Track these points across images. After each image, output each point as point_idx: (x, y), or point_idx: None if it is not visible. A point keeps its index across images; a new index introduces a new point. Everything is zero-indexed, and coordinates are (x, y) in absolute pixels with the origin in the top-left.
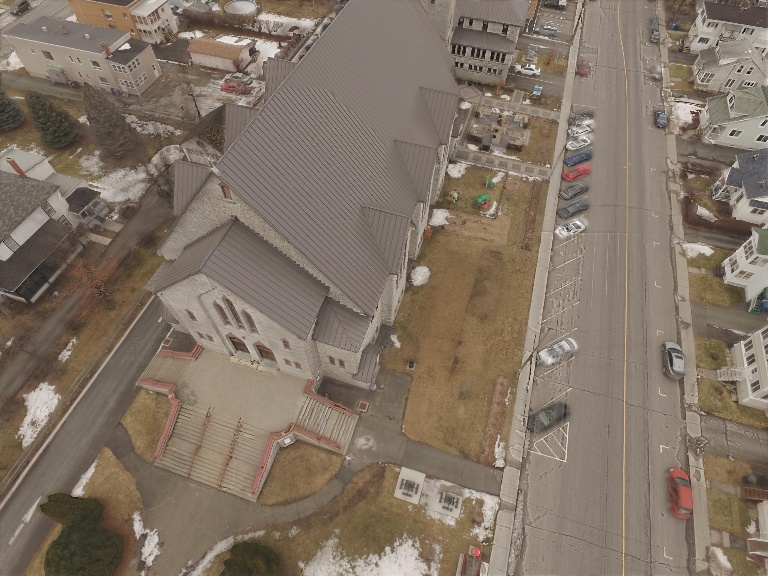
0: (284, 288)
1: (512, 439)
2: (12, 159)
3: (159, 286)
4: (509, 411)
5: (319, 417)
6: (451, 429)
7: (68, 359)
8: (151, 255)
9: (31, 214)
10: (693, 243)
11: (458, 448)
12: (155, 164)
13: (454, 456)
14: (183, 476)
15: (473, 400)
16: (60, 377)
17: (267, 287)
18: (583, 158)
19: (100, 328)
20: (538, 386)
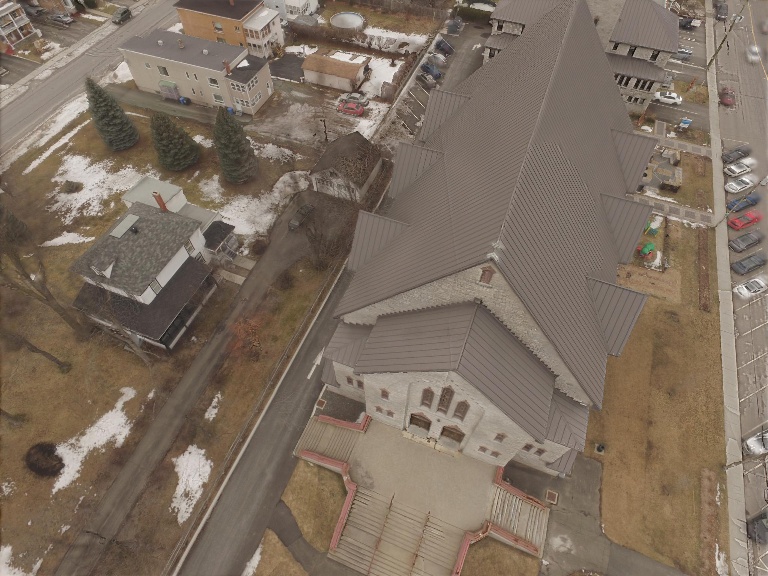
0: (522, 382)
1: (733, 550)
2: (158, 193)
3: (365, 366)
4: (723, 514)
5: (511, 511)
6: (659, 533)
7: (215, 418)
8: (289, 298)
9: (176, 254)
10: None
11: (672, 558)
12: (279, 192)
13: (669, 568)
14: (361, 573)
15: (679, 497)
16: (210, 439)
17: (509, 383)
18: (748, 203)
19: (245, 382)
20: (750, 483)
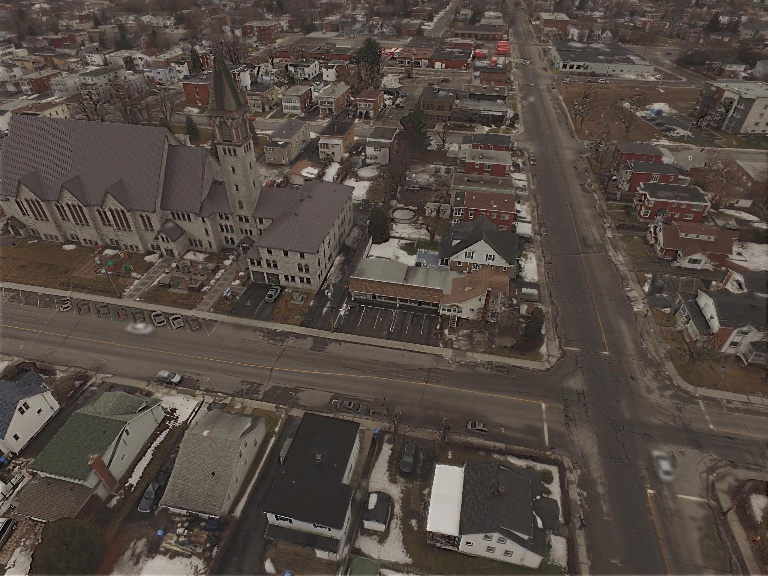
0: None
1: None
2: None
3: None
4: None
5: (5, 221)
6: None
7: None
8: None
9: None
10: (5, 367)
11: None
12: None
13: None
14: None
15: None
16: None
17: None
18: (138, 319)
19: None
20: None
